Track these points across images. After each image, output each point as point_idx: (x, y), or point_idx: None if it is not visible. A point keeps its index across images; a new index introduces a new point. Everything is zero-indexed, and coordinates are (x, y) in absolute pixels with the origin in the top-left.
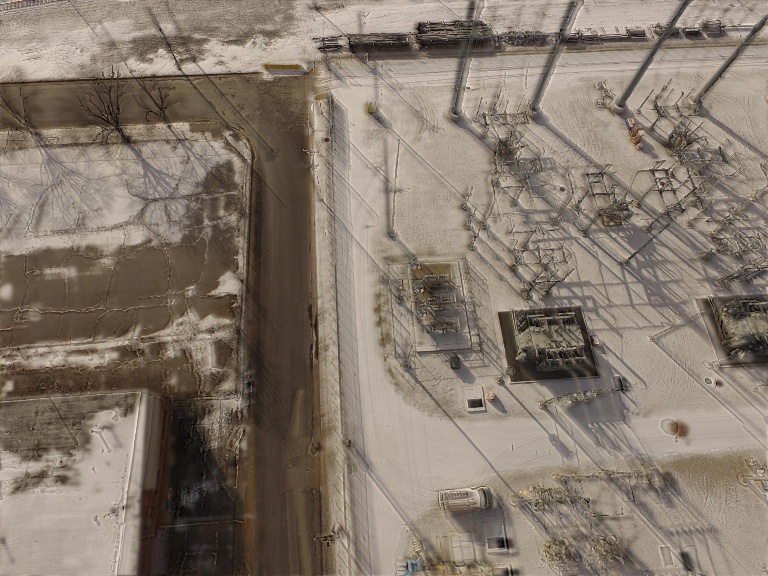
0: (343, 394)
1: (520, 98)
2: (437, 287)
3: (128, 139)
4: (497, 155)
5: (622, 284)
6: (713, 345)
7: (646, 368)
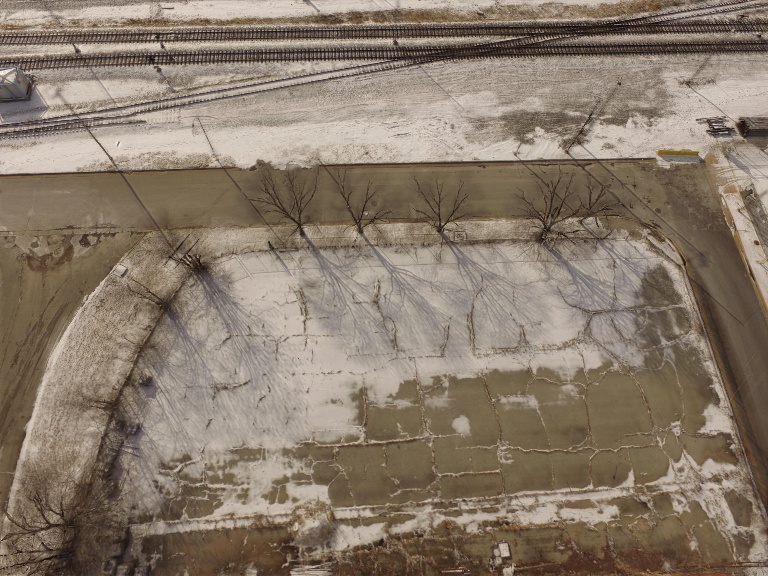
0: None
1: None
2: None
3: None
4: None
5: None
6: None
7: None
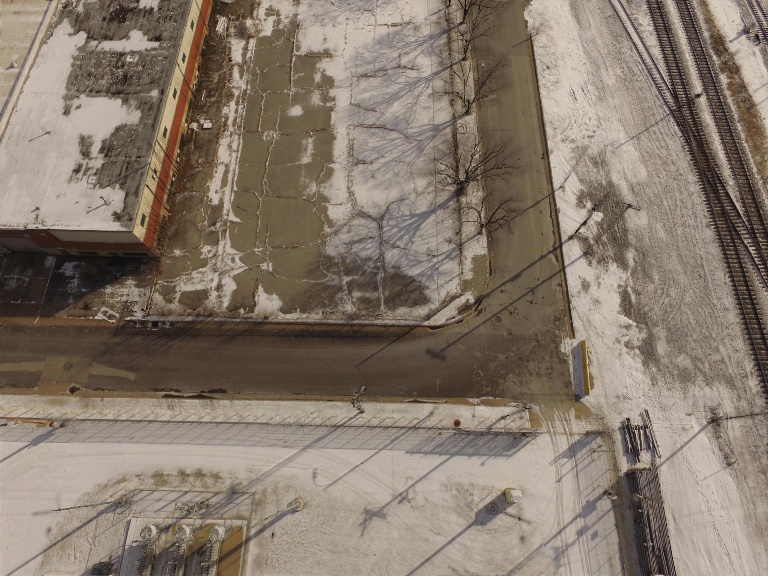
0: (115, 423)
1: None
2: None
3: (463, 195)
4: None
5: None
6: None
7: None
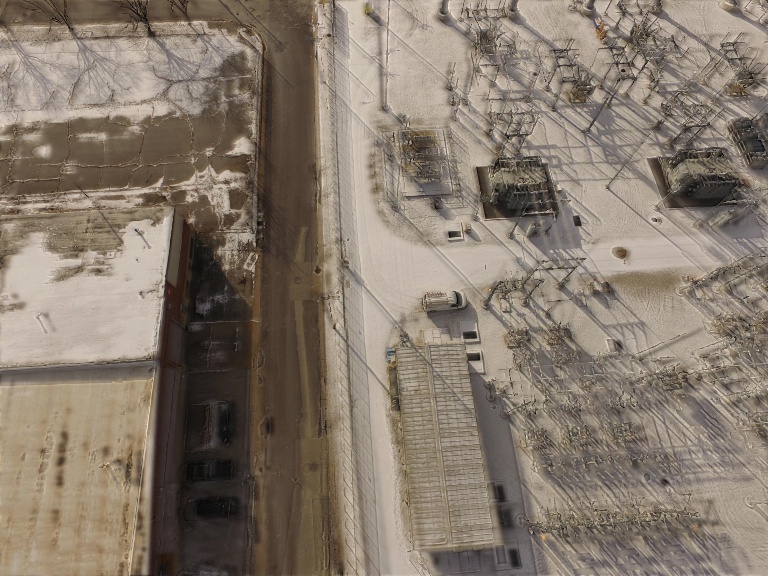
0: (343, 229)
1: (501, 3)
2: (424, 146)
3: (154, 33)
4: (477, 37)
5: (584, 147)
6: (660, 193)
7: (602, 209)
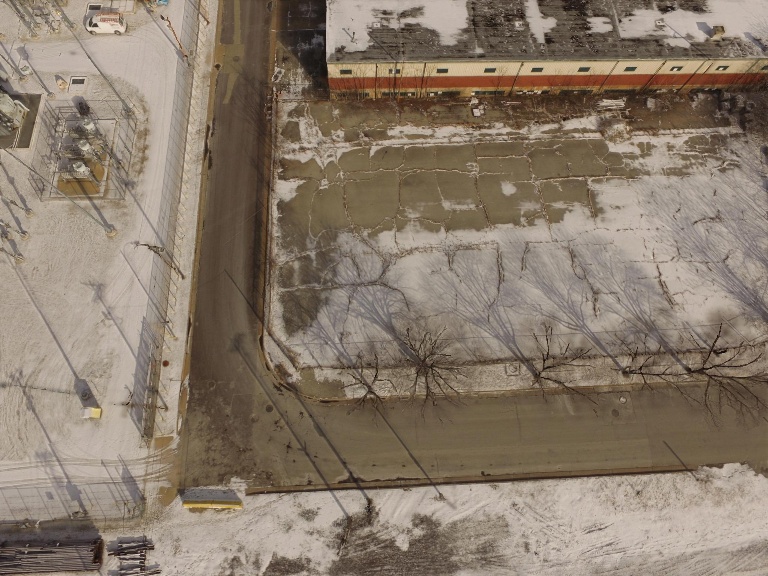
0: (188, 98)
1: None
2: None
3: None
4: None
5: None
6: None
7: None
